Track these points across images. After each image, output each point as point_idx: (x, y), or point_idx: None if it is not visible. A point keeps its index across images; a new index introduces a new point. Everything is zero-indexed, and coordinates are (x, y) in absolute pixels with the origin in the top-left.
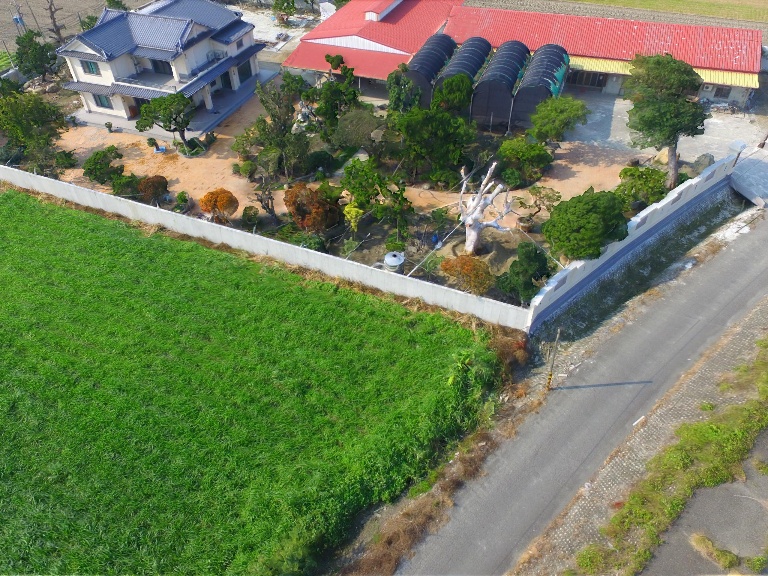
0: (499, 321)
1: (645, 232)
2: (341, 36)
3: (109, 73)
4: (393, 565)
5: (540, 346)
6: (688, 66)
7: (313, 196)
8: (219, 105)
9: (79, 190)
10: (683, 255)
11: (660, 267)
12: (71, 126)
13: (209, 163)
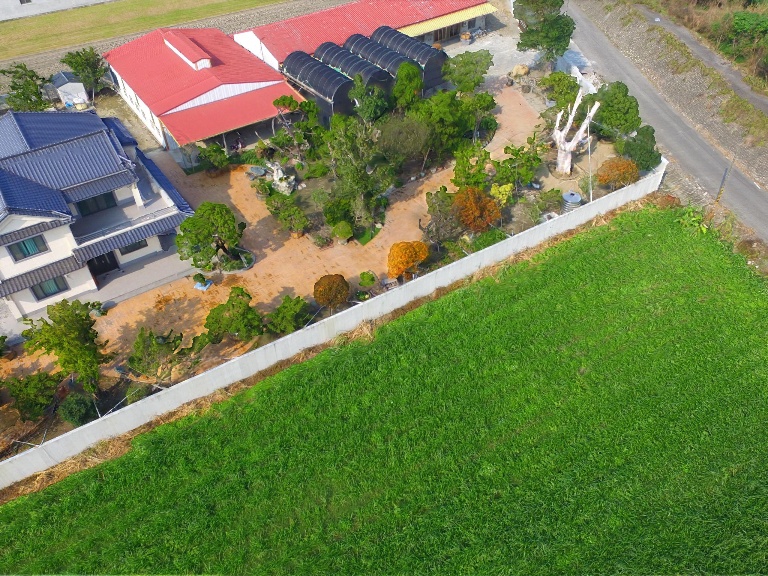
0: None
1: None
2: (207, 92)
3: (67, 239)
4: None
5: None
6: None
7: (480, 194)
8: None
9: (248, 359)
10: None
11: None
12: None
13: (278, 258)
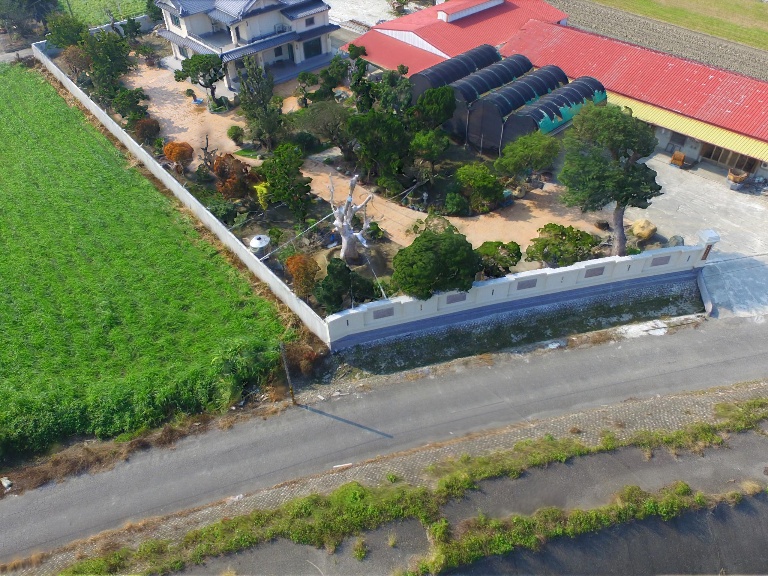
0: (310, 328)
1: (536, 296)
2: (401, 30)
3: (184, 27)
4: (38, 480)
5: (340, 366)
6: (634, 125)
7: (234, 167)
8: (274, 74)
9: (106, 118)
10: (570, 335)
11: (536, 338)
12: (157, 67)
13: (222, 121)
